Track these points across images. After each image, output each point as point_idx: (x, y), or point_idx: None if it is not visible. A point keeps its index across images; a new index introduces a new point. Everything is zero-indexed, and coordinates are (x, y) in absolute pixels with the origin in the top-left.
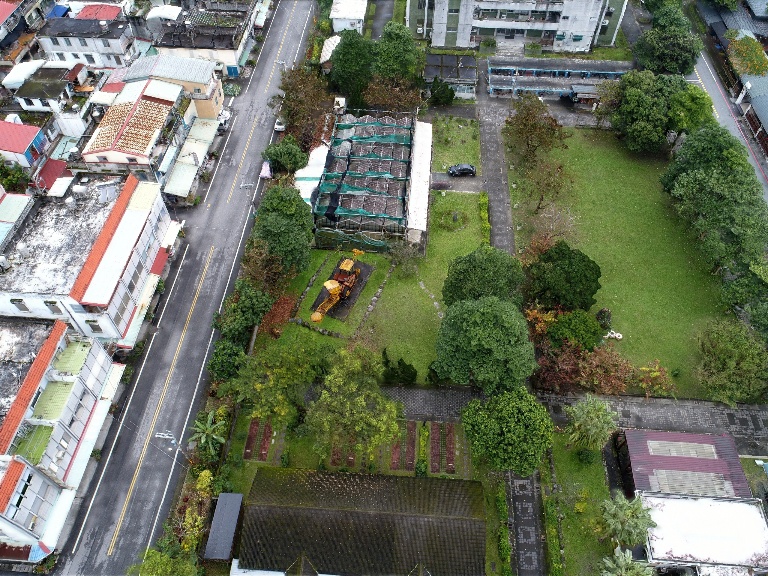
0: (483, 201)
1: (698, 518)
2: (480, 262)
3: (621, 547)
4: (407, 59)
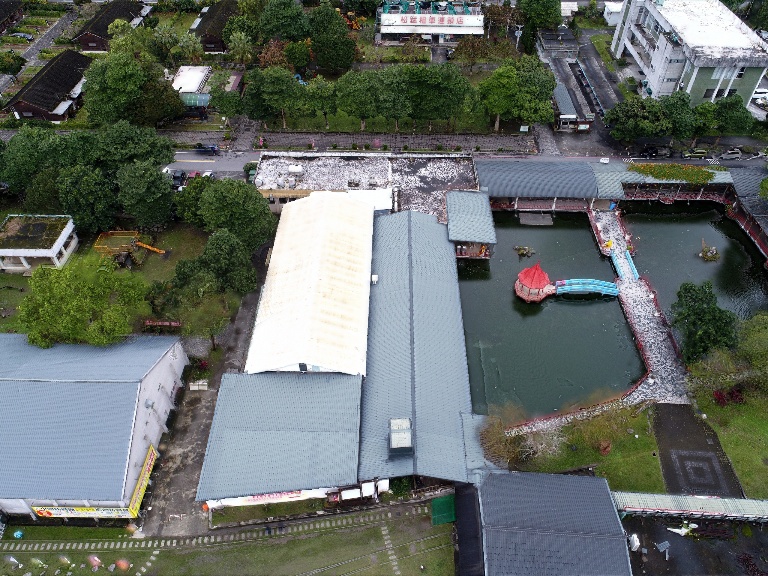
0: None
1: (193, 77)
2: (324, 6)
3: (189, 64)
4: (533, 5)
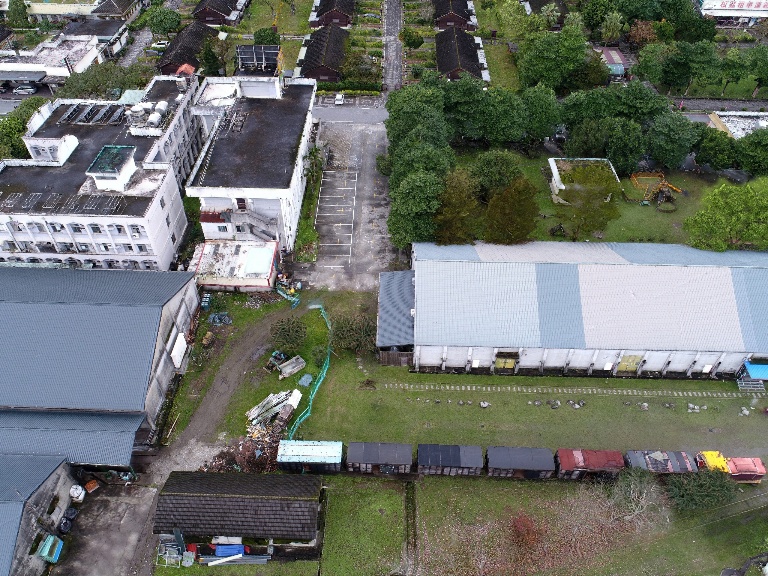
0: (747, 36)
1: None
2: None
3: None
4: None
